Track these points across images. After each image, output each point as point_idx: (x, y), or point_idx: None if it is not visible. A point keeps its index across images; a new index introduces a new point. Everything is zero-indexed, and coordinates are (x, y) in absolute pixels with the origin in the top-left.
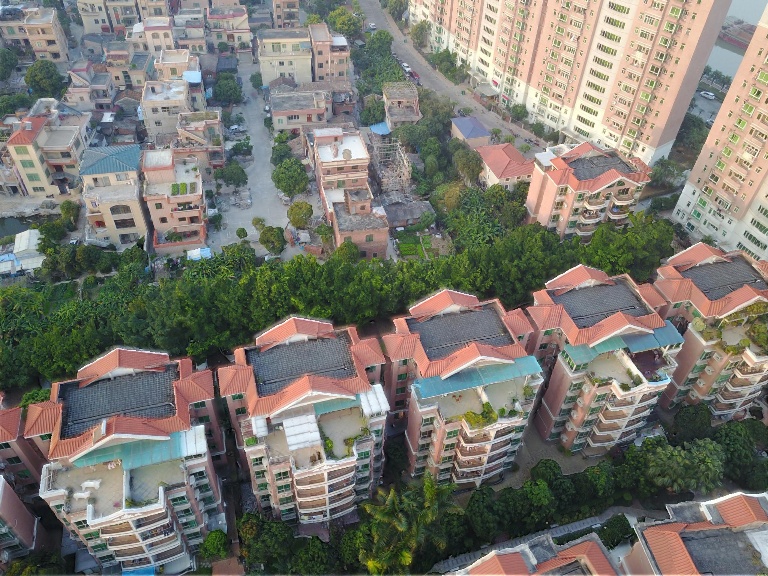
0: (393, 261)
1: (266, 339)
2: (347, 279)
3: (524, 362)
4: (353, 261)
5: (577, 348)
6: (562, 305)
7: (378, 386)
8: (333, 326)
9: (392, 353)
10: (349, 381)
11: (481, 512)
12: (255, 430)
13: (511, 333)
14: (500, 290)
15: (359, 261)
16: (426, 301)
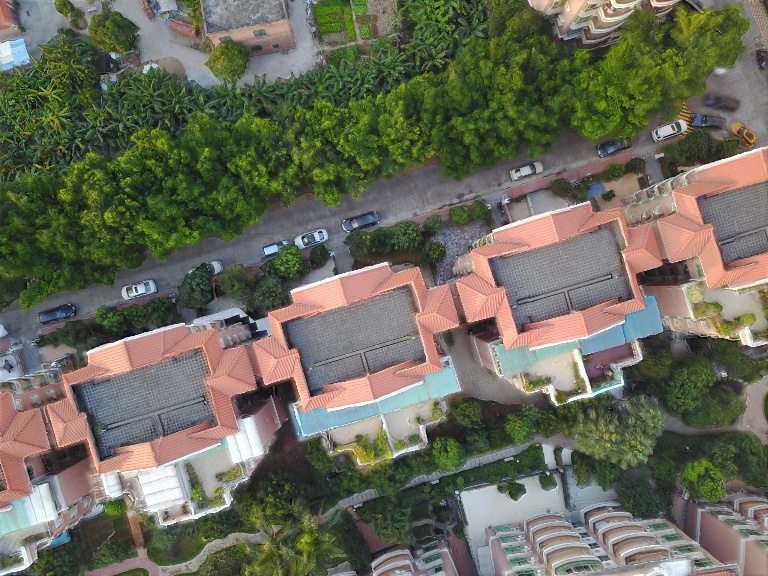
0: (289, 113)
1: (98, 360)
2: (221, 158)
3: (436, 380)
4: (239, 73)
5: (512, 351)
6: (504, 291)
7: (249, 421)
8: (210, 235)
9: (264, 375)
10: (208, 432)
11: (382, 483)
12: (107, 489)
13: (423, 344)
14: (446, 160)
15: (253, 54)
16: (311, 287)
